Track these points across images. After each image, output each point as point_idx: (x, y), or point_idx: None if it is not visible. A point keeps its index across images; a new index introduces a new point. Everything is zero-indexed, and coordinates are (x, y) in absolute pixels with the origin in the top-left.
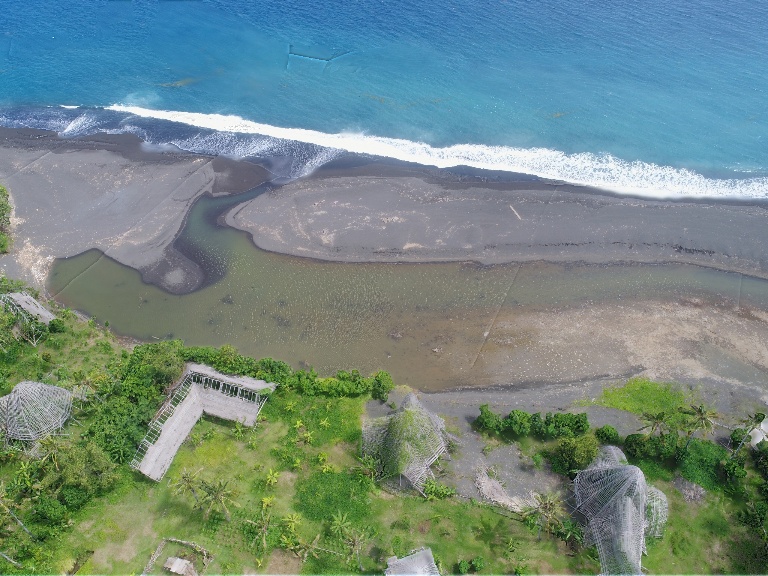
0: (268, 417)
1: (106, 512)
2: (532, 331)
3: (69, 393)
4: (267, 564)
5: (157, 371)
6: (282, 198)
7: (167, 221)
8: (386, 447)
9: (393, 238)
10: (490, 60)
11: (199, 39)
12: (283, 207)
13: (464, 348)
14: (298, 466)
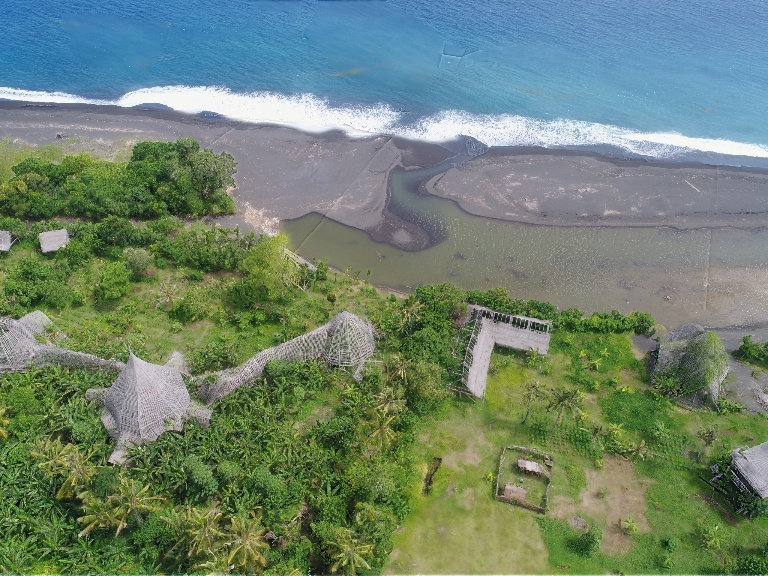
0: (550, 349)
1: (437, 427)
2: (745, 283)
3: (368, 327)
4: (603, 466)
5: (452, 306)
6: (473, 172)
7: (373, 189)
8: (684, 367)
9: (592, 205)
10: (618, 59)
11: (358, 30)
12: (477, 179)
13: (692, 296)
14: (598, 387)
